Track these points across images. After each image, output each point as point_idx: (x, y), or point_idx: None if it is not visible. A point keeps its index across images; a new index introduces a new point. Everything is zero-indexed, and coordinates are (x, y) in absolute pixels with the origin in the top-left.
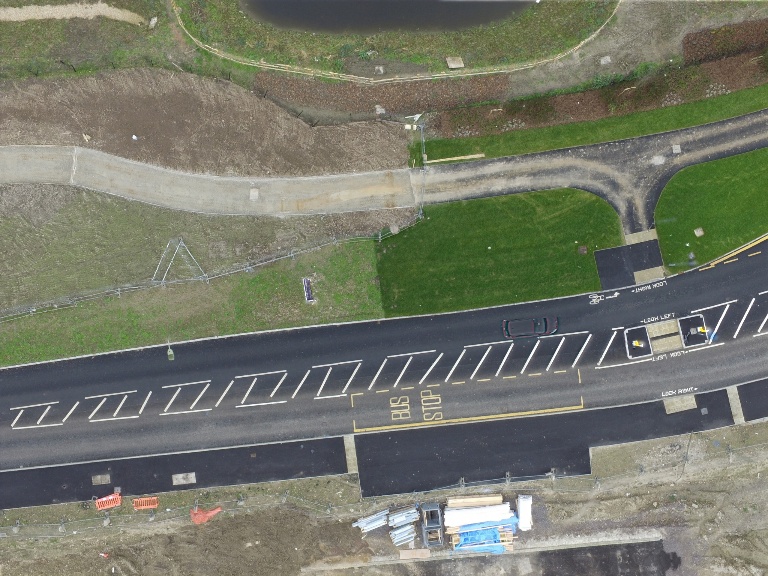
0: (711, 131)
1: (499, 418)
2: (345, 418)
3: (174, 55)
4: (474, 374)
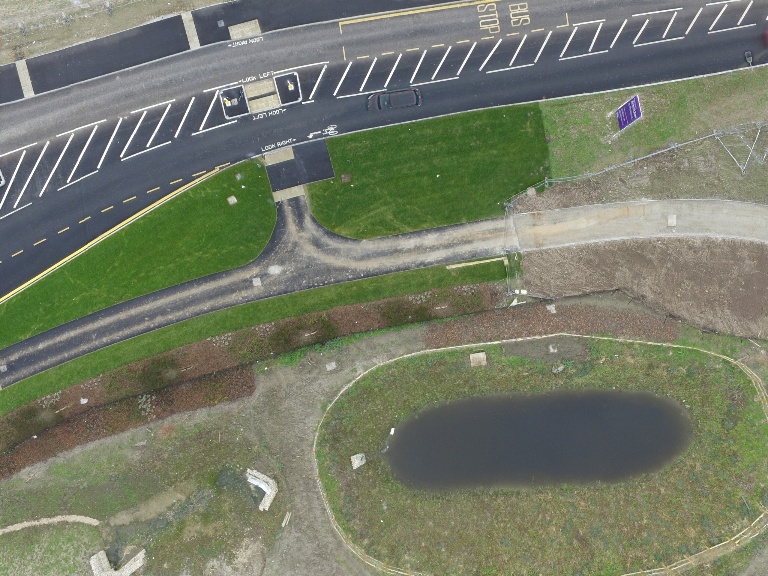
0: (224, 301)
1: (422, 8)
2: (574, 2)
3: (759, 354)
4: (448, 51)
